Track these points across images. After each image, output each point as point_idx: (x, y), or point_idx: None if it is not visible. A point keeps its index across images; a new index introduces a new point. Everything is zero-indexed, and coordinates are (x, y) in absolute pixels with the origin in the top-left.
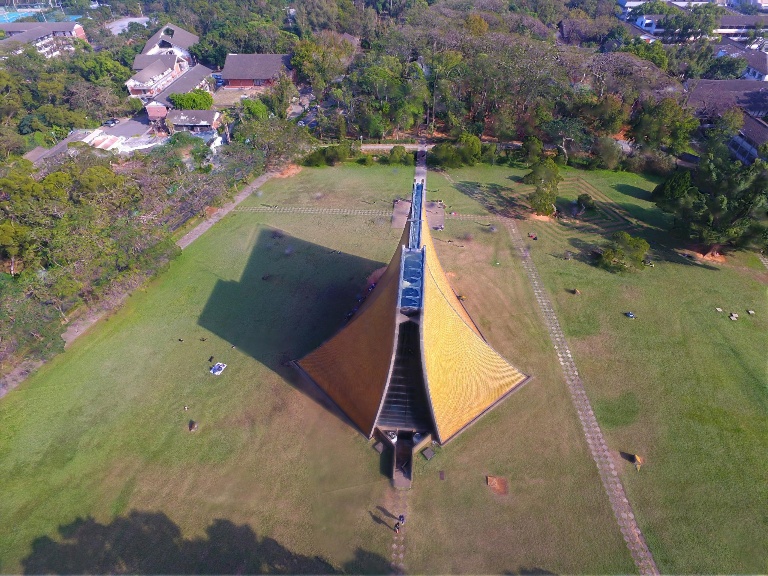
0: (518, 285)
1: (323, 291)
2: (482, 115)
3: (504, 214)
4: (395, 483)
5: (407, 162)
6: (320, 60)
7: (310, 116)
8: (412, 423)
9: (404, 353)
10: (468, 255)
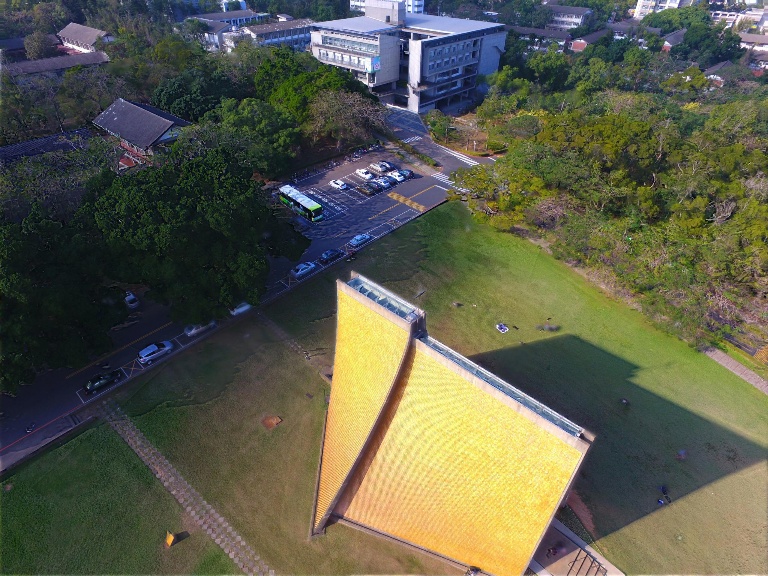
0: None
1: None
2: None
3: None
4: (329, 367)
5: None
6: None
7: None
8: None
9: None
10: None
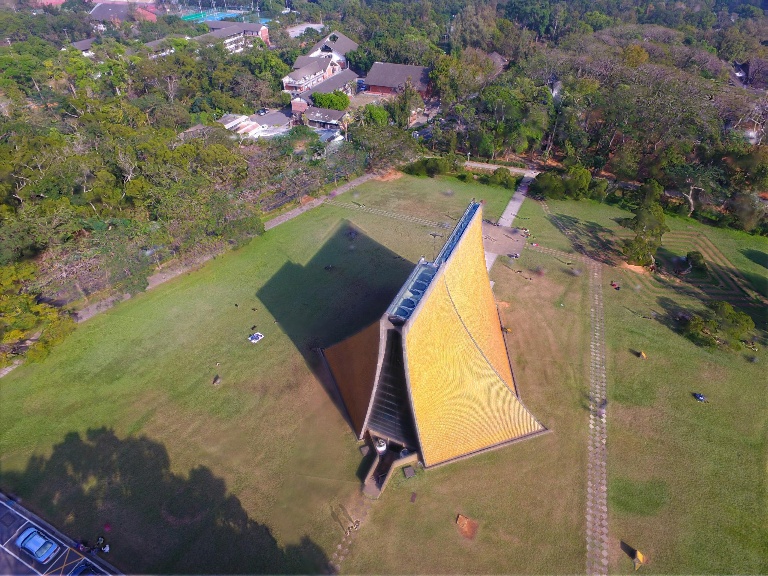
0: (575, 332)
1: (373, 291)
2: (606, 149)
3: (592, 256)
4: (365, 488)
5: (508, 185)
6: (456, 76)
7: (431, 128)
8: (402, 437)
9: (393, 362)
10: (533, 289)
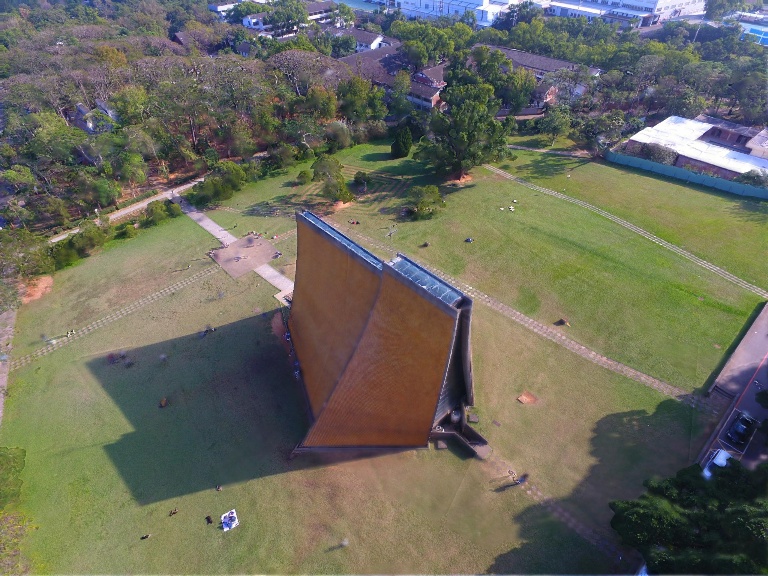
0: None
1: (244, 372)
2: None
3: None
4: (481, 456)
5: (174, 214)
6: None
7: None
8: (447, 407)
9: None
10: None
